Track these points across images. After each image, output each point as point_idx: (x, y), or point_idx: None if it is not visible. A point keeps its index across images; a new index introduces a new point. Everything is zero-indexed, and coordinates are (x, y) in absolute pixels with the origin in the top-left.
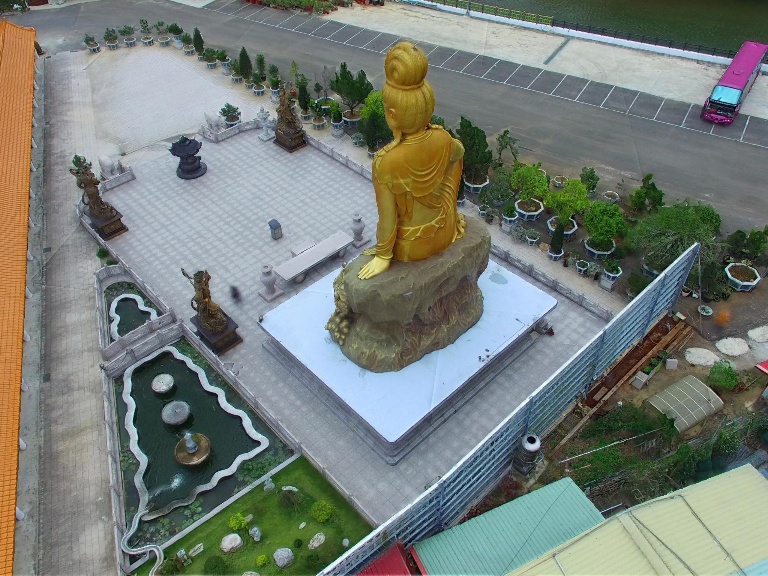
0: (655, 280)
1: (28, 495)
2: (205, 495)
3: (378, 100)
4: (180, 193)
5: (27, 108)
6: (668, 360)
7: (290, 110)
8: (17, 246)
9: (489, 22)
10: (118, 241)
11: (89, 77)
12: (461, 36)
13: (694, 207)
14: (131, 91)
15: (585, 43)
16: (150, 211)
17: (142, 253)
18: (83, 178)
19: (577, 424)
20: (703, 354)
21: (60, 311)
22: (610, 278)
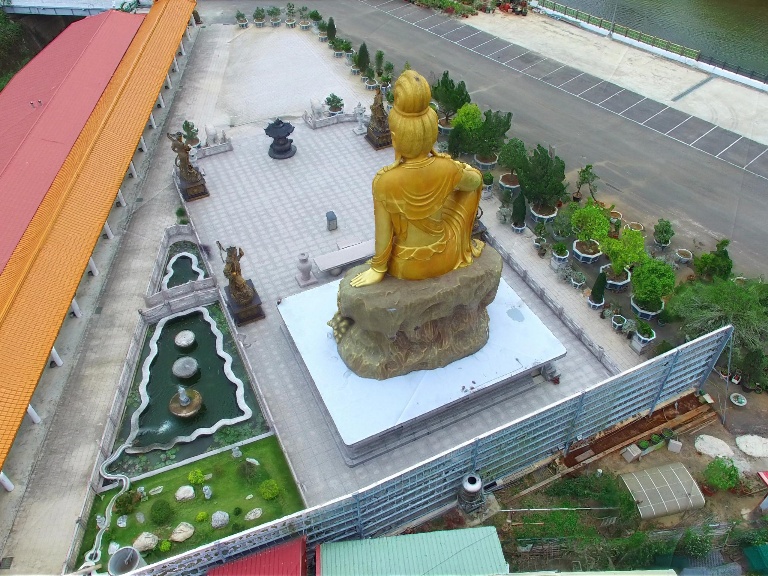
0: (663, 354)
1: (49, 405)
2: (183, 446)
3: (470, 113)
4: (265, 170)
5: (163, 72)
6: (671, 441)
7: (382, 110)
8: (109, 192)
9: (630, 47)
10: (198, 204)
11: (230, 50)
12: (593, 58)
13: (765, 286)
14: (260, 68)
15: (729, 84)
16: (233, 182)
17: (213, 219)
18: (177, 143)
19: (546, 479)
20: (717, 445)
21: (130, 255)
22: (641, 340)
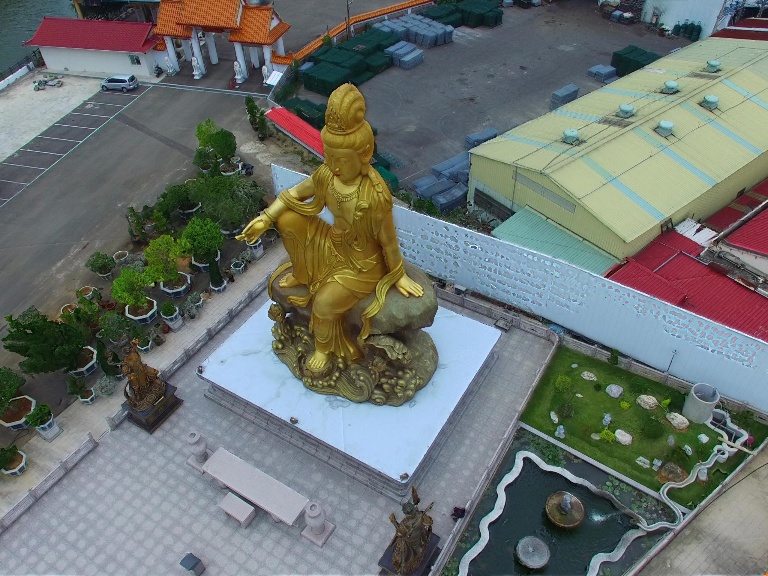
0: None
1: None
2: None
3: None
4: None
5: None
6: None
7: None
8: None
9: None
10: None
11: None
12: None
13: (174, 192)
14: None
15: None
16: None
17: None
18: None
19: None
20: None
21: None
22: None
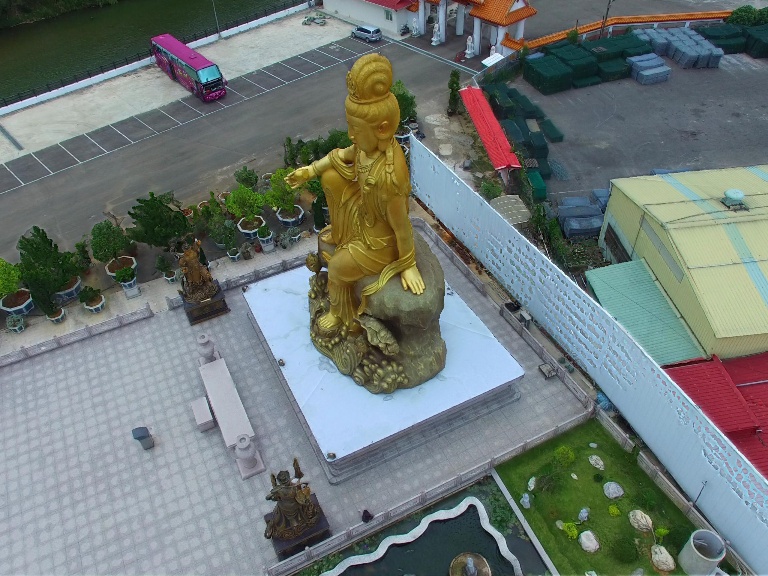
0: None
1: None
2: (523, 571)
3: None
4: None
5: None
6: None
7: None
8: None
9: None
10: None
11: None
12: None
13: (334, 136)
14: None
15: (15, 116)
16: None
17: None
18: None
19: None
20: None
21: None
22: None
